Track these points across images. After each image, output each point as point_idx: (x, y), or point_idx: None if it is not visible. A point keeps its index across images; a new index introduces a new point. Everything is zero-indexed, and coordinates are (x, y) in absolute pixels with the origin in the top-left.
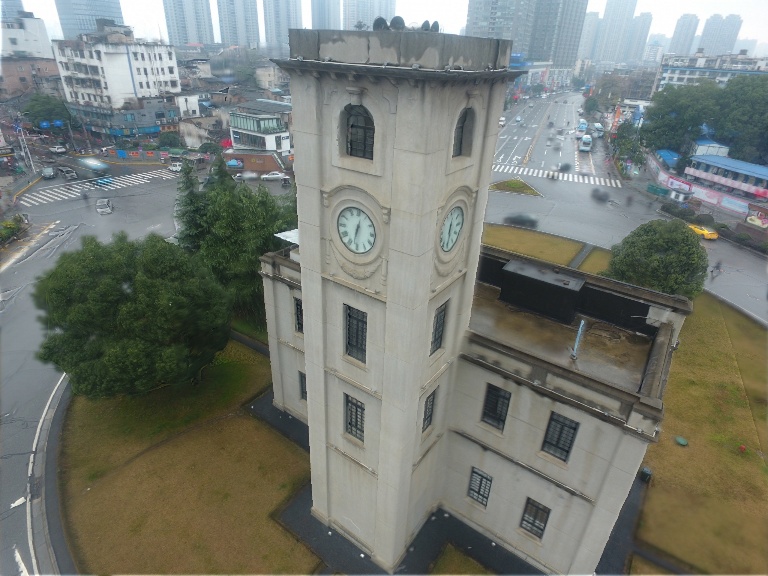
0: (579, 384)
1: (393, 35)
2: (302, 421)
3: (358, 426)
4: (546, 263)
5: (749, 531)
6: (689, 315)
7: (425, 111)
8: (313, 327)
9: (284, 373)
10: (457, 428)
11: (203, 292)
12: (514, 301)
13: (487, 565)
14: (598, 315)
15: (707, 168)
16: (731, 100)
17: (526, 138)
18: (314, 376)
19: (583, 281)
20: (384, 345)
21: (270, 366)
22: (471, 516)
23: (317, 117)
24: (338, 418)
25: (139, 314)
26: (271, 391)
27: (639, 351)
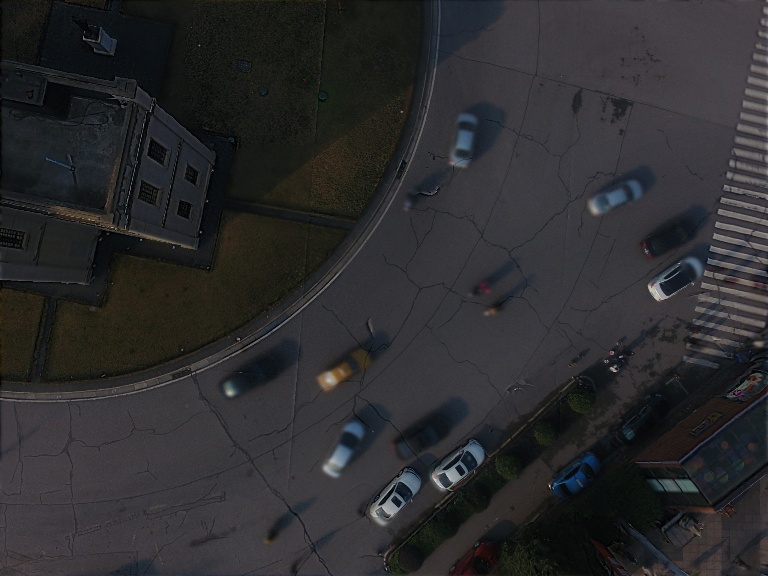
0: None
1: None
2: None
3: None
4: (5, 67)
5: (293, 161)
6: None
7: None
8: None
9: None
10: (51, 216)
11: None
12: (13, 106)
13: (140, 255)
14: (87, 96)
15: None
16: None
17: None
18: None
19: (44, 84)
20: None
21: None
22: None
23: None
24: None
25: None
26: None
27: None
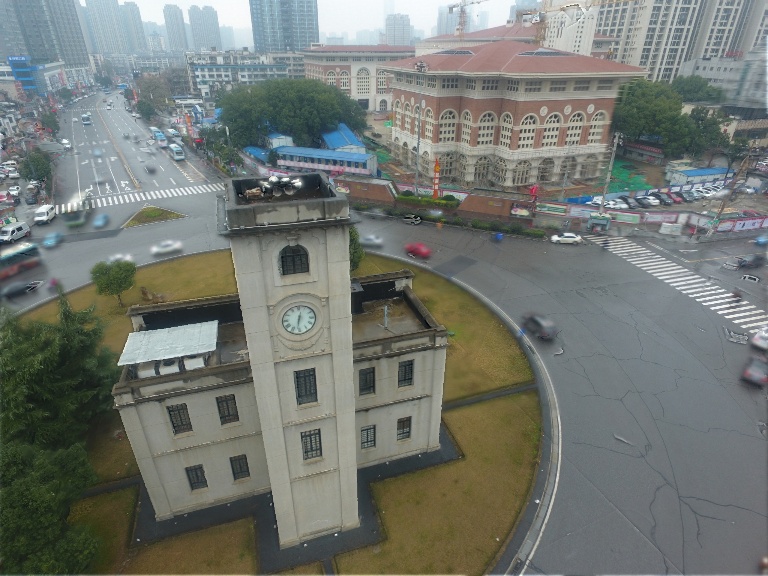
0: (409, 339)
1: (316, 203)
2: (199, 509)
3: (313, 449)
4: None
5: (463, 367)
6: (358, 270)
7: (346, 239)
8: (269, 403)
9: (165, 482)
10: None
11: (53, 466)
12: None
13: (394, 475)
14: (371, 298)
15: (292, 158)
16: (277, 101)
17: (111, 158)
18: (273, 438)
19: (359, 283)
20: (332, 380)
21: (110, 500)
22: (368, 459)
23: (259, 260)
24: (297, 455)
25: (11, 533)
26: (139, 515)
27: (404, 307)
